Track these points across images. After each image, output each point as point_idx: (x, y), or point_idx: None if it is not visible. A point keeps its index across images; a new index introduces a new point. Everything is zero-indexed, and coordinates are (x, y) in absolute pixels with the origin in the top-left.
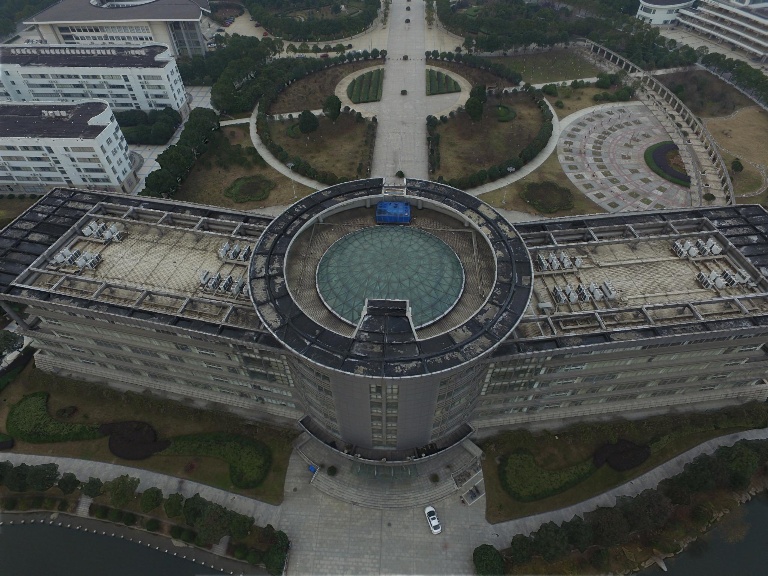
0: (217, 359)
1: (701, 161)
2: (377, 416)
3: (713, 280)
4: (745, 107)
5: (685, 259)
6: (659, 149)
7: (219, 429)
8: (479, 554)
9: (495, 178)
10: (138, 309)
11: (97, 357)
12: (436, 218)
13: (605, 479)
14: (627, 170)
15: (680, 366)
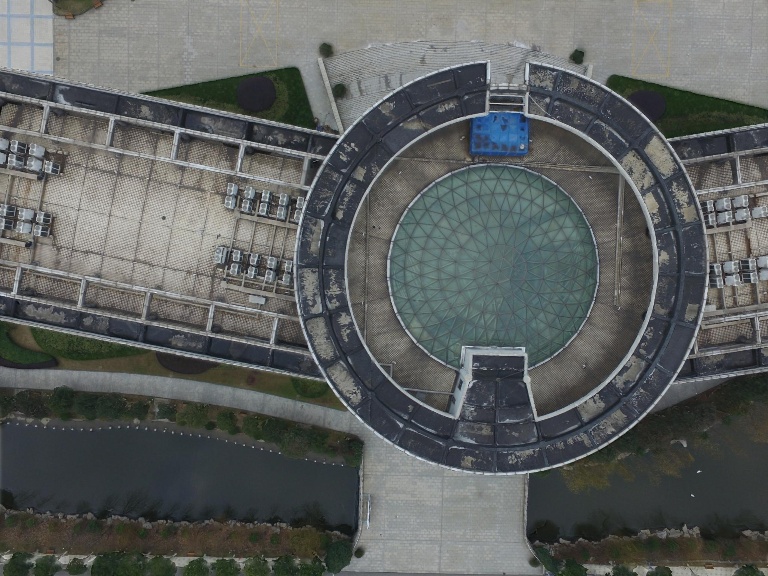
0: None
1: None
2: None
3: None
4: None
5: None
6: None
7: None
8: None
9: None
10: (152, 325)
11: None
12: (565, 138)
13: None
14: None
15: None
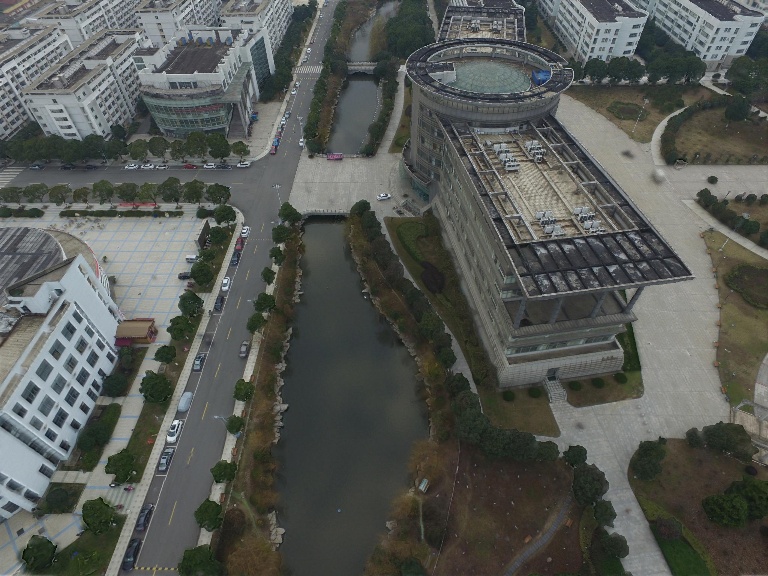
0: None
1: None
2: None
3: None
4: None
5: None
6: None
7: None
8: None
9: (765, 245)
10: None
11: None
12: None
13: (414, 268)
14: None
15: None
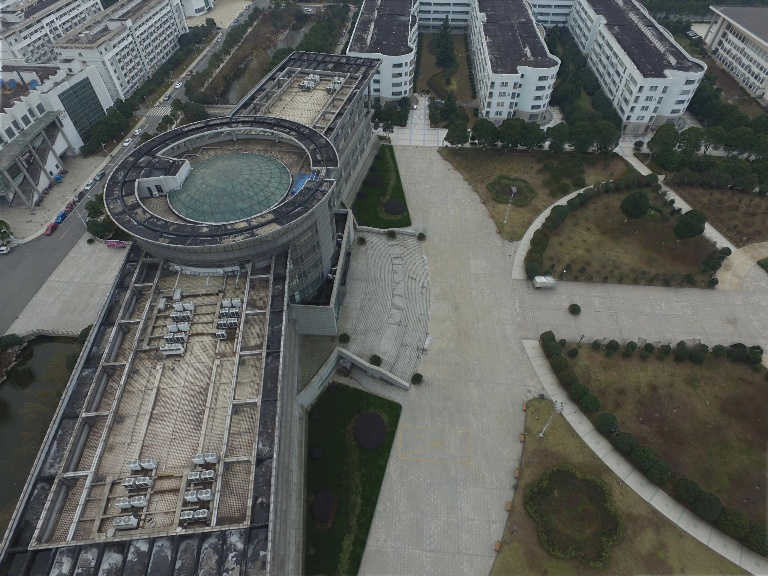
0: None
1: None
2: None
3: None
4: None
5: (194, 467)
6: None
7: None
8: None
9: None
10: None
11: None
12: None
13: None
14: None
15: None
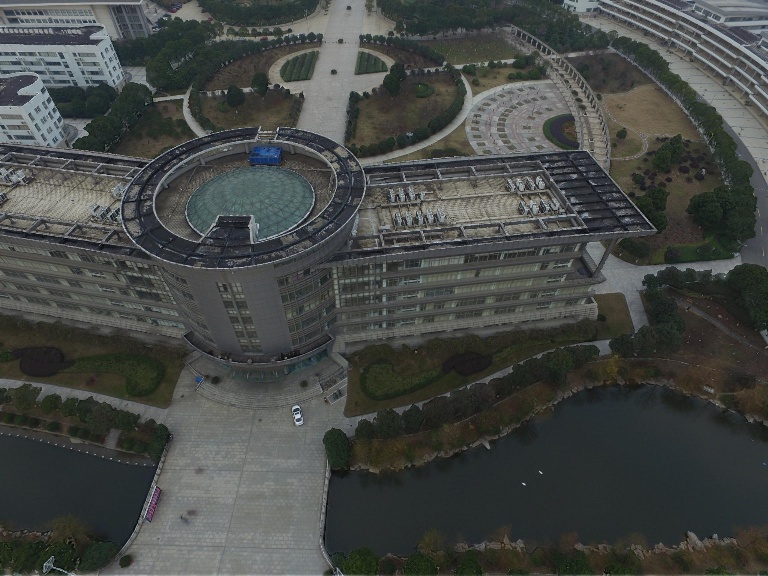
0: (107, 281)
1: (593, 130)
2: (234, 317)
3: (531, 208)
4: (643, 85)
5: (515, 193)
6: (557, 120)
7: (121, 351)
8: (327, 435)
9: (404, 145)
10: (31, 233)
11: (9, 289)
12: (304, 161)
13: (450, 382)
14: (525, 138)
15: (507, 282)
